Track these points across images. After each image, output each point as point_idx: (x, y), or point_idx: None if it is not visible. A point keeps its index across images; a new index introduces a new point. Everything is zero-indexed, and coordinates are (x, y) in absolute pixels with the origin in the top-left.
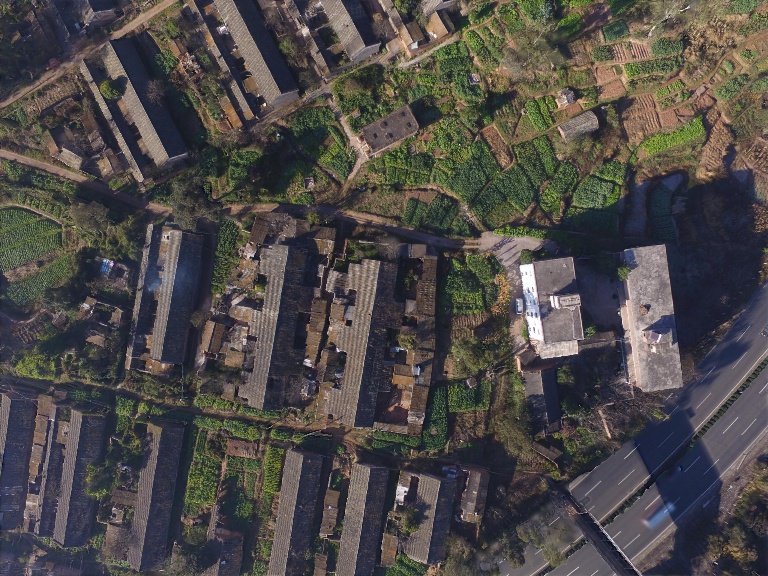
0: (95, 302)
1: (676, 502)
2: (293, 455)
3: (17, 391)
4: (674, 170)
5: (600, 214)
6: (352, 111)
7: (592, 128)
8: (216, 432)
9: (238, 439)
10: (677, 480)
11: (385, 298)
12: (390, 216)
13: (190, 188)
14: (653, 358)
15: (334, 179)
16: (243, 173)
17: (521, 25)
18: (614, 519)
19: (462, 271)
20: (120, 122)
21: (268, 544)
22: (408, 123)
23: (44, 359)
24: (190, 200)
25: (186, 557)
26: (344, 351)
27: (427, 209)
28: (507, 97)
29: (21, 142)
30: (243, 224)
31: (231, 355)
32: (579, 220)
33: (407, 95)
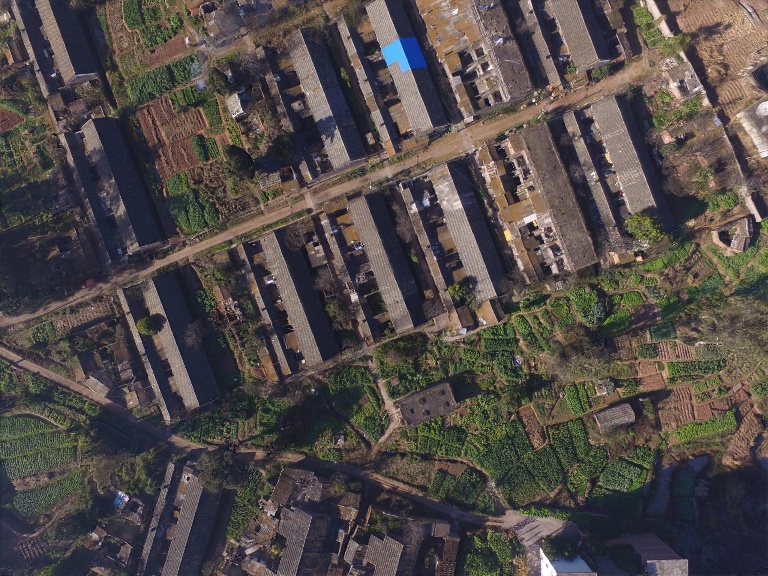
0: (105, 535)
1: None
2: None
3: None
4: (701, 454)
5: (625, 498)
6: (391, 376)
7: (628, 421)
8: None
9: None
10: None
11: None
12: (417, 485)
13: (220, 467)
14: None
15: (364, 439)
16: (272, 420)
17: (571, 320)
18: None
19: (482, 548)
20: (153, 357)
21: None
22: (447, 402)
23: None
24: (219, 480)
25: None
26: None
27: (455, 482)
28: None
29: (47, 356)
30: (267, 473)
31: None
32: (603, 502)
33: (448, 367)
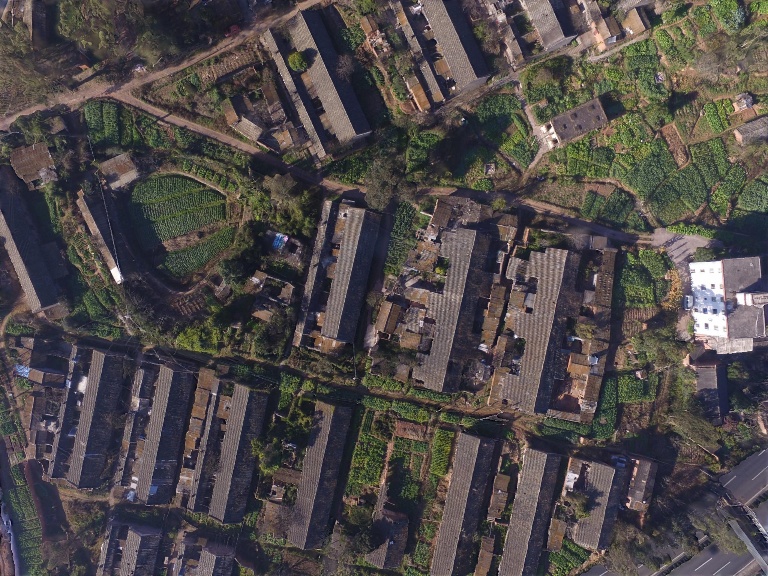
0: (266, 276)
1: None
2: (468, 438)
3: (180, 363)
4: None
5: (763, 217)
6: (538, 100)
7: (767, 133)
8: (384, 413)
9: (406, 421)
10: None
11: (568, 287)
12: (568, 207)
13: (396, 166)
14: None
15: (514, 167)
16: (422, 155)
17: (713, 28)
18: None
19: (635, 265)
20: (303, 95)
21: (432, 526)
22: (597, 116)
23: (219, 331)
24: (396, 178)
25: (355, 536)
26: None
27: (605, 202)
28: (688, 97)
29: (193, 109)
30: (421, 206)
31: (407, 336)
32: (743, 222)
33: (593, 88)
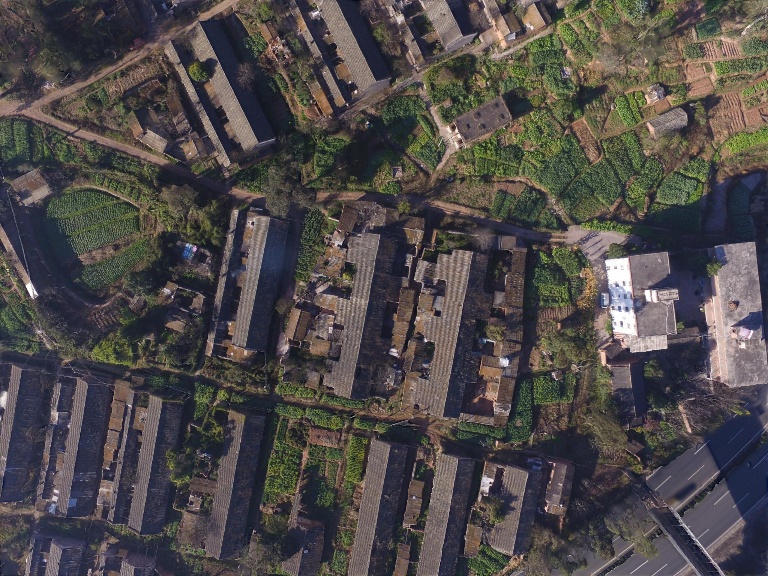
0: (176, 287)
1: (745, 498)
2: (379, 444)
3: (94, 376)
4: (754, 169)
5: (683, 211)
6: (443, 101)
7: (681, 125)
8: (298, 420)
9: (320, 428)
10: (746, 476)
11: (476, 289)
12: (478, 207)
13: (289, 173)
14: (740, 354)
15: (422, 169)
16: (330, 160)
17: (617, 20)
18: (684, 514)
19: (549, 264)
20: (207, 105)
21: (349, 534)
22: (501, 114)
23: (127, 343)
24: (289, 185)
25: (268, 545)
26: (432, 341)
27: (515, 201)
28: (597, 91)
29: (102, 123)
30: (329, 212)
31: (317, 343)
32: (663, 216)
33: (499, 86)
